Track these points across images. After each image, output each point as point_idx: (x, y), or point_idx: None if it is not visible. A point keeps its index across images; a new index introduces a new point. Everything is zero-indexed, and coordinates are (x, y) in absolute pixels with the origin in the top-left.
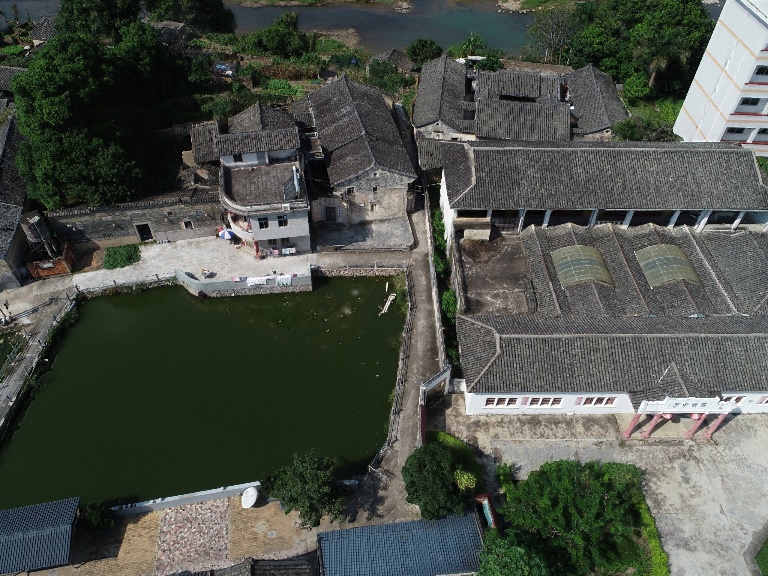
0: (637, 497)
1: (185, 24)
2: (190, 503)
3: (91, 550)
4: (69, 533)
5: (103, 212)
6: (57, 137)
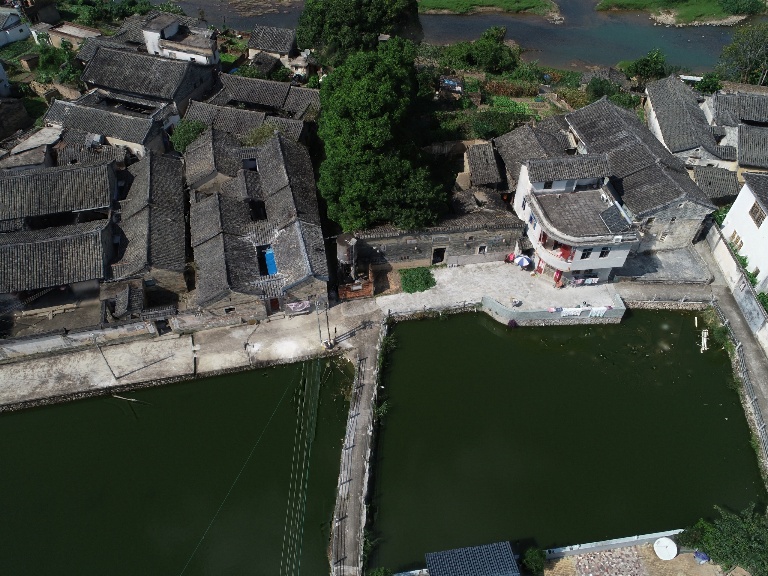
0: None
1: (388, 35)
2: (599, 550)
3: None
4: None
5: (410, 235)
6: (375, 159)
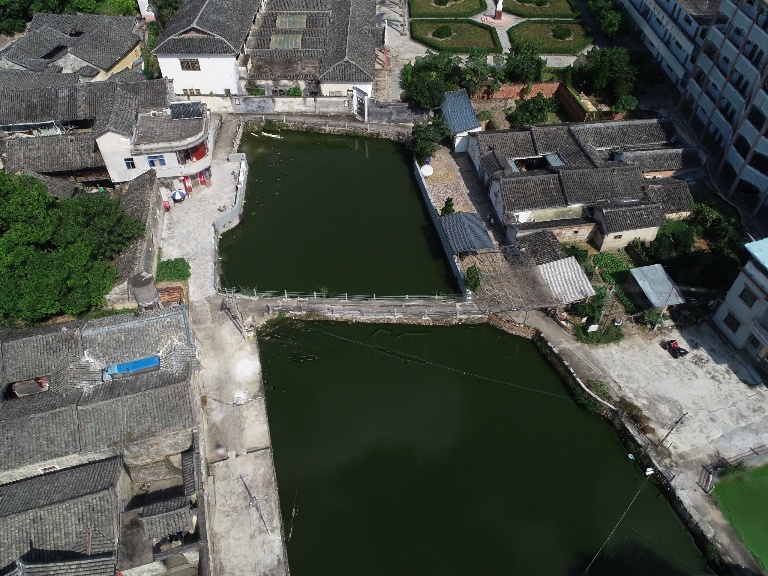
0: None
1: None
2: None
3: None
4: (464, 213)
5: (142, 241)
6: None
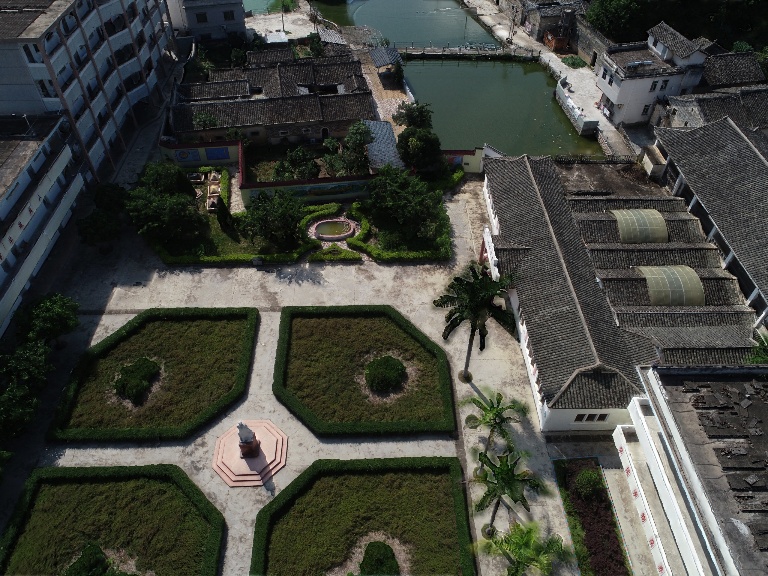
0: (420, 235)
1: None
2: None
3: (387, 84)
4: (387, 64)
5: (590, 30)
6: None
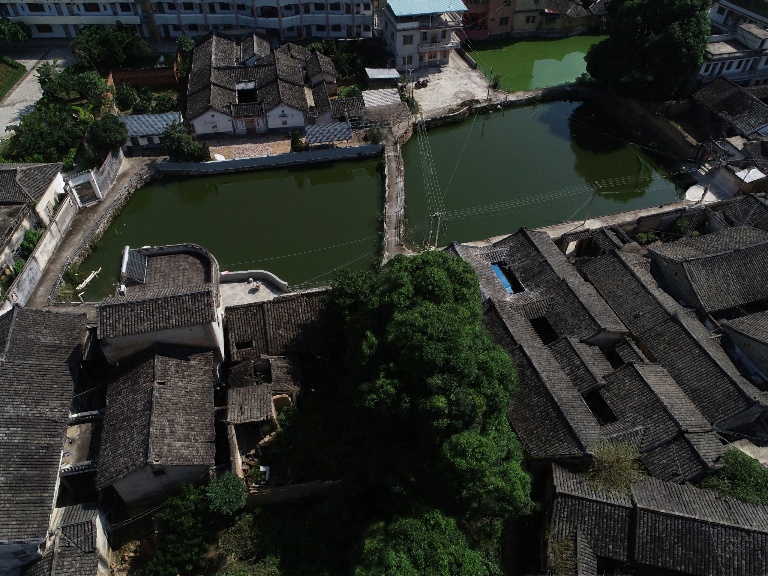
0: None
1: None
2: None
3: None
4: None
5: None
6: None
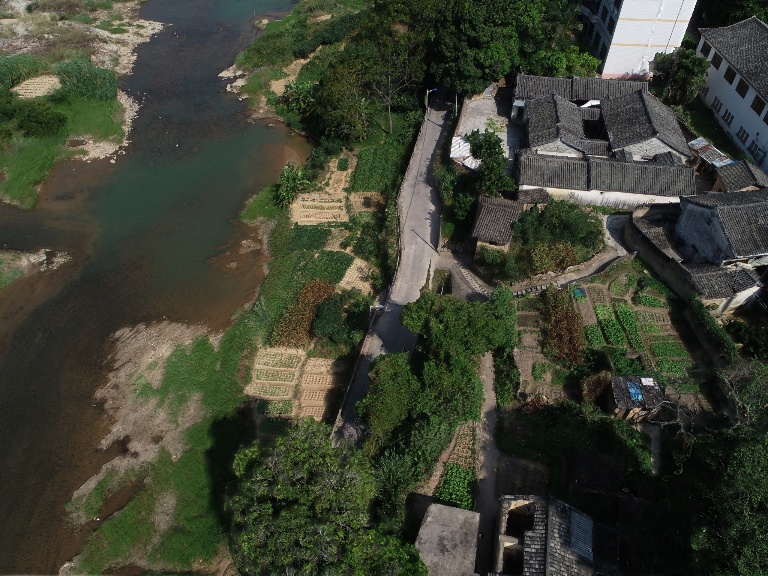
0: None
1: None
2: None
3: None
4: None
5: None
6: None
